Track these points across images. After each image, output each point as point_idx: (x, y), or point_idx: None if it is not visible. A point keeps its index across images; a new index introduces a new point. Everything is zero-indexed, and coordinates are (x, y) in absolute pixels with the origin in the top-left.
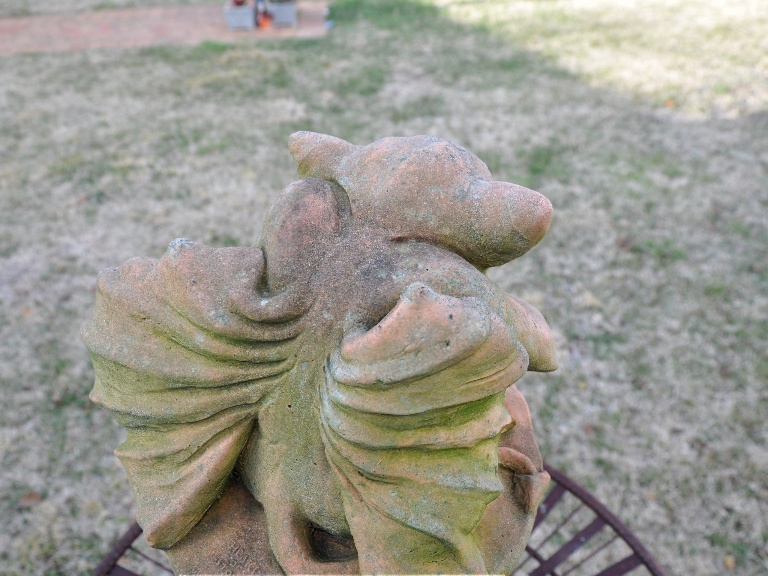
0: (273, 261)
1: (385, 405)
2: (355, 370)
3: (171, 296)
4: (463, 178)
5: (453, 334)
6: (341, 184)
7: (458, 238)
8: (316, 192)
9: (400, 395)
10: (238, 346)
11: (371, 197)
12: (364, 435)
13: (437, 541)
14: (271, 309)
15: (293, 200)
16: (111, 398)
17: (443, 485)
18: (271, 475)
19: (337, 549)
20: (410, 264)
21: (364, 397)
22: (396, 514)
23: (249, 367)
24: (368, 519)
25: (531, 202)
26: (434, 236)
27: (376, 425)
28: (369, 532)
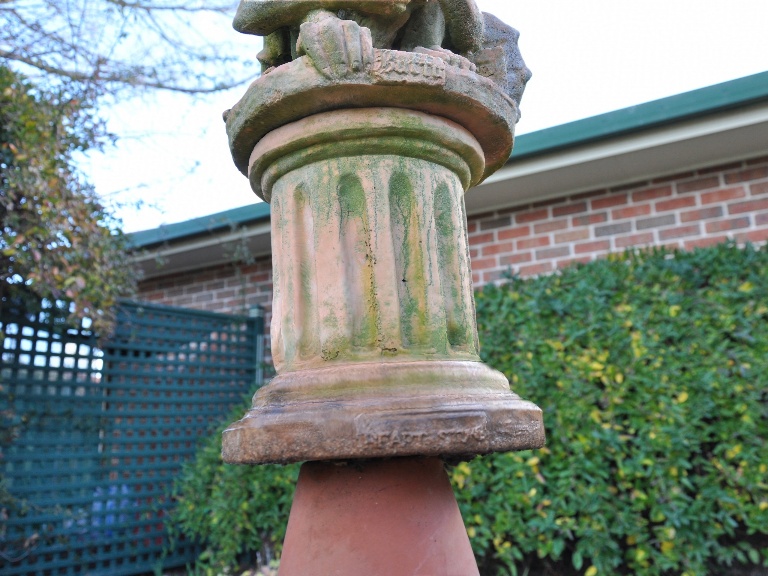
0: None
1: None
2: None
3: None
4: None
5: None
6: None
7: None
8: None
9: None
10: None
11: None
12: None
13: None
14: None
15: None
16: None
17: None
18: None
19: None
20: None
21: None
22: None
23: None
24: None
25: None
26: None
27: None
28: None
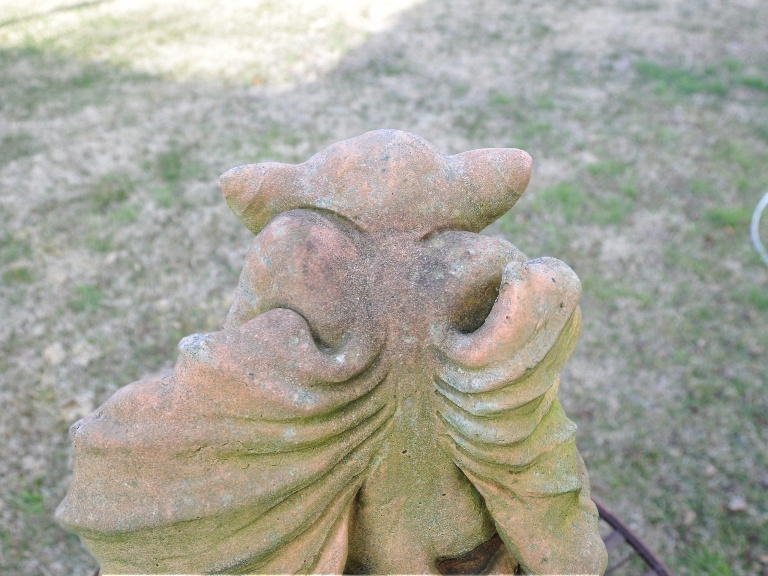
0: (316, 313)
1: (534, 390)
2: (500, 371)
3: (227, 405)
4: (439, 159)
5: (563, 295)
6: (323, 207)
7: (466, 216)
8: (315, 223)
9: (541, 374)
10: (331, 419)
11: (375, 207)
12: (520, 430)
13: (573, 494)
14: (354, 361)
15: (300, 240)
16: (164, 574)
17: (562, 442)
18: (389, 538)
19: (469, 568)
20: (459, 254)
21: (515, 393)
22: (549, 490)
23: (348, 436)
24: (523, 512)
25: (516, 159)
26: (450, 222)
27: (525, 415)
28: (527, 523)
